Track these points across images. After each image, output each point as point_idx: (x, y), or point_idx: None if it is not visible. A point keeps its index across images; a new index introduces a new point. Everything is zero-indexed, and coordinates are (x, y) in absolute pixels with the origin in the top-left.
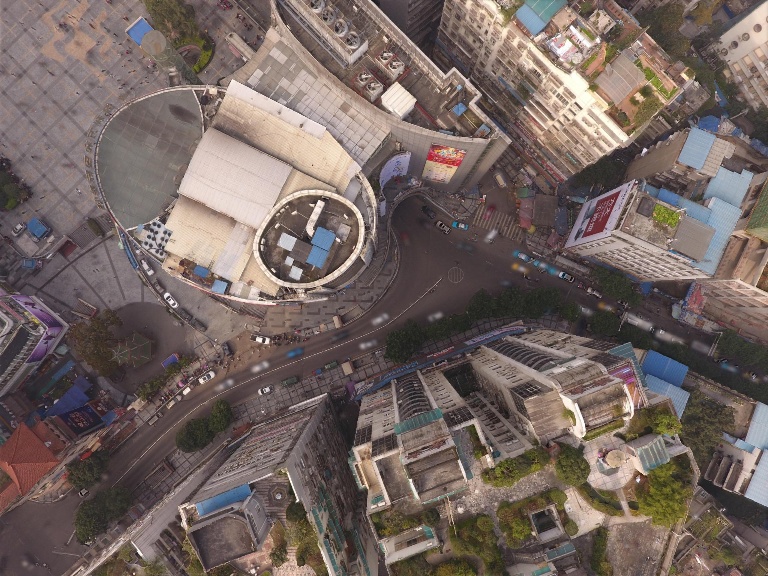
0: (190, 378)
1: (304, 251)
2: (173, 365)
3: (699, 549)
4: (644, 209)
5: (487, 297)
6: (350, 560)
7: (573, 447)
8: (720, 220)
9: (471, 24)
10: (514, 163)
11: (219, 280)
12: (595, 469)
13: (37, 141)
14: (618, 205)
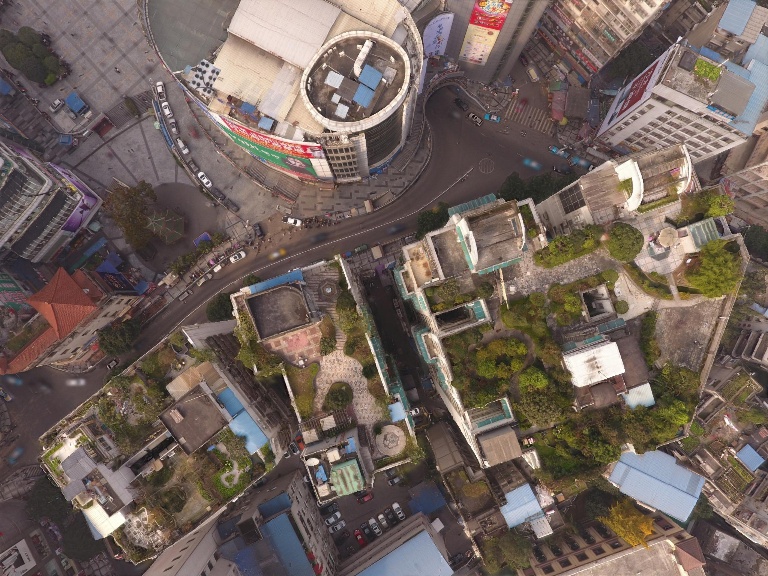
0: (221, 257)
1: (351, 89)
2: (205, 242)
3: (727, 412)
4: (686, 62)
5: (519, 179)
6: (390, 381)
7: None
8: (759, 82)
9: None
10: (547, 60)
11: (266, 117)
12: (646, 254)
13: (78, 19)
14: (657, 70)
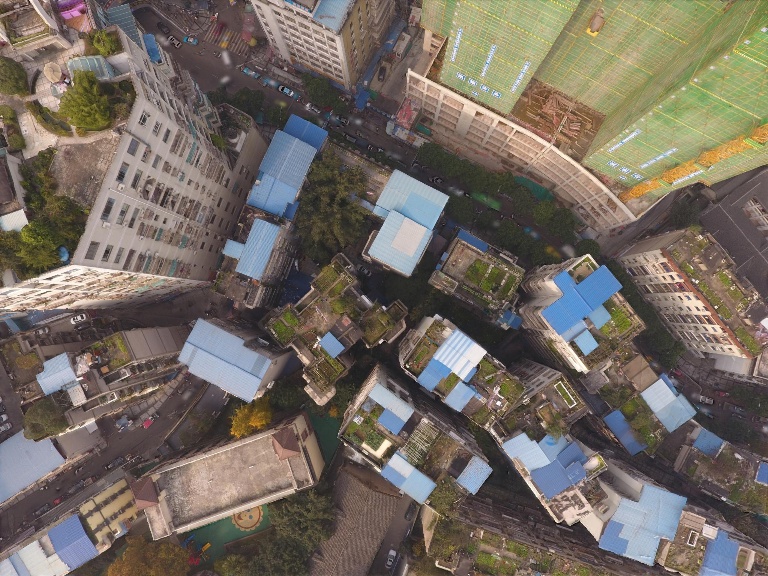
0: None
1: None
2: None
3: (323, 304)
4: None
5: None
6: None
7: (14, 60)
8: None
9: None
10: None
11: None
12: (49, 93)
13: None
14: None
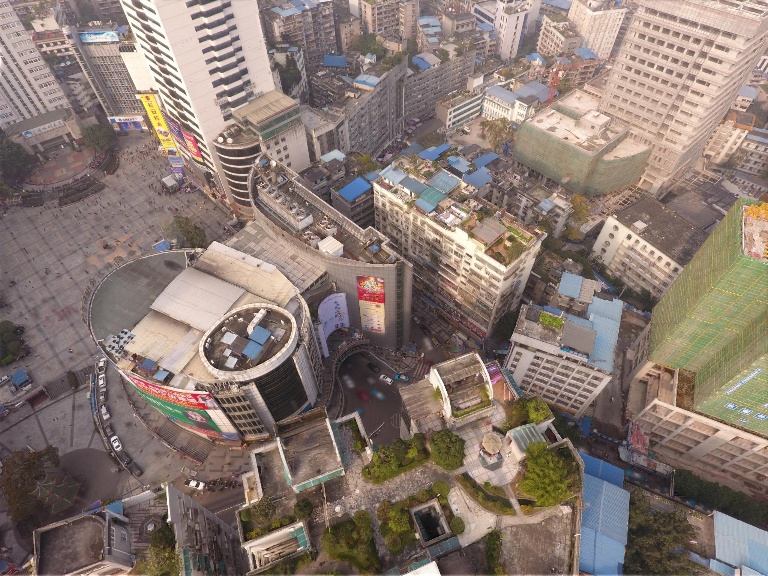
0: None
1: (242, 344)
2: None
3: None
4: (531, 316)
5: None
6: None
7: None
8: (603, 330)
9: (392, 221)
10: (447, 331)
11: (162, 370)
12: (478, 464)
13: (54, 315)
14: None
